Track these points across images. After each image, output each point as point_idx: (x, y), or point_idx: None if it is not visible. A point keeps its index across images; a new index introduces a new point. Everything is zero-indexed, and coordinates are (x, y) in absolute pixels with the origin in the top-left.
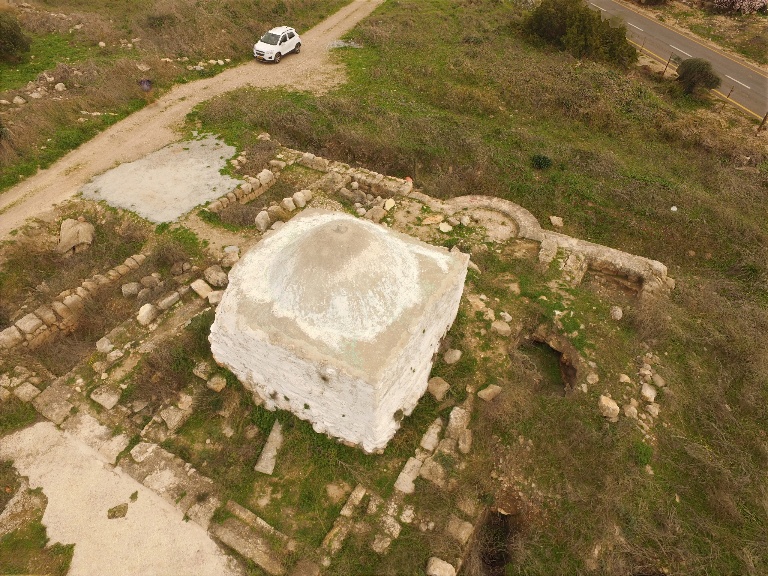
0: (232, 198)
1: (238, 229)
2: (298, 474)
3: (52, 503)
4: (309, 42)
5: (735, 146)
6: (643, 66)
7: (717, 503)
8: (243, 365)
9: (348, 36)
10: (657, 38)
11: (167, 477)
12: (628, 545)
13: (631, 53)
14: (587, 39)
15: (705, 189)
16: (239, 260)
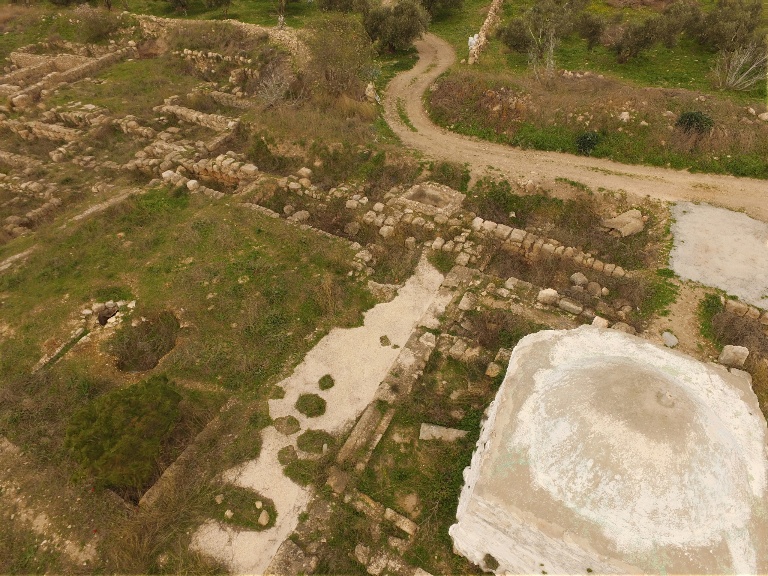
0: (766, 319)
1: (708, 336)
2: (423, 463)
3: (389, 304)
4: None
5: None
6: None
7: None
8: None
9: None
10: None
11: (409, 361)
12: None
13: None
14: None
15: None
16: None
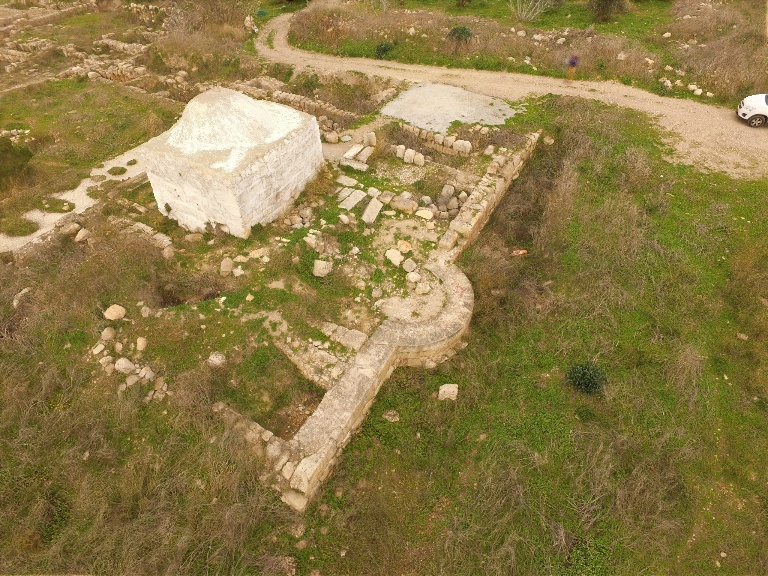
0: (422, 134)
1: None
2: None
3: None
4: None
5: None
6: None
7: None
8: None
9: None
10: None
11: None
12: None
13: None
14: None
15: None
16: None
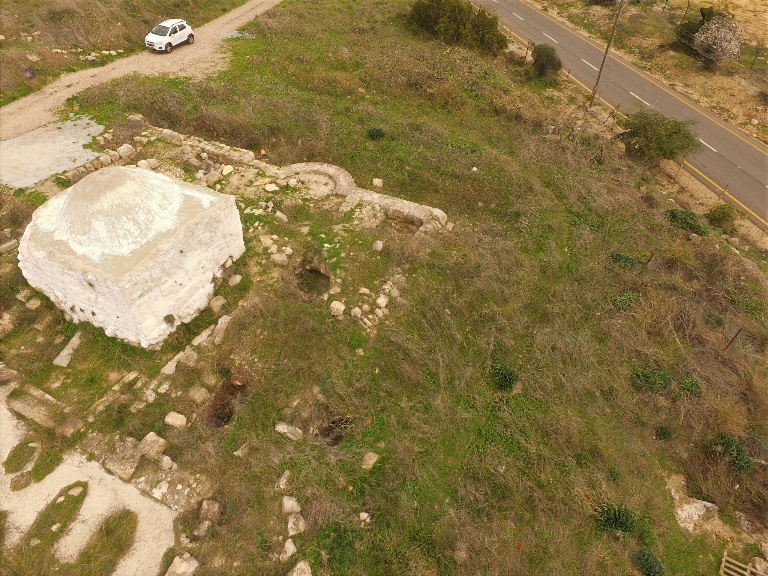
0: (90, 168)
1: None
2: (88, 366)
3: None
4: (206, 33)
5: (547, 118)
6: (509, 52)
7: (397, 369)
8: (48, 286)
9: (244, 28)
10: (533, 27)
11: None
12: (322, 399)
13: (500, 40)
14: (459, 28)
15: (510, 153)
16: (43, 204)
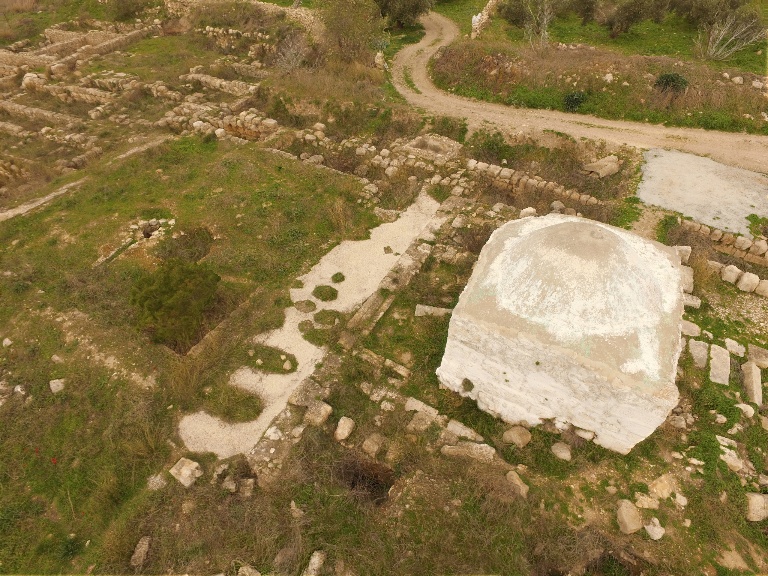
0: (715, 235)
1: None
2: (417, 332)
3: (392, 224)
4: None
5: None
6: None
7: None
8: None
9: None
10: None
11: (408, 262)
12: None
13: None
14: None
15: None
16: None
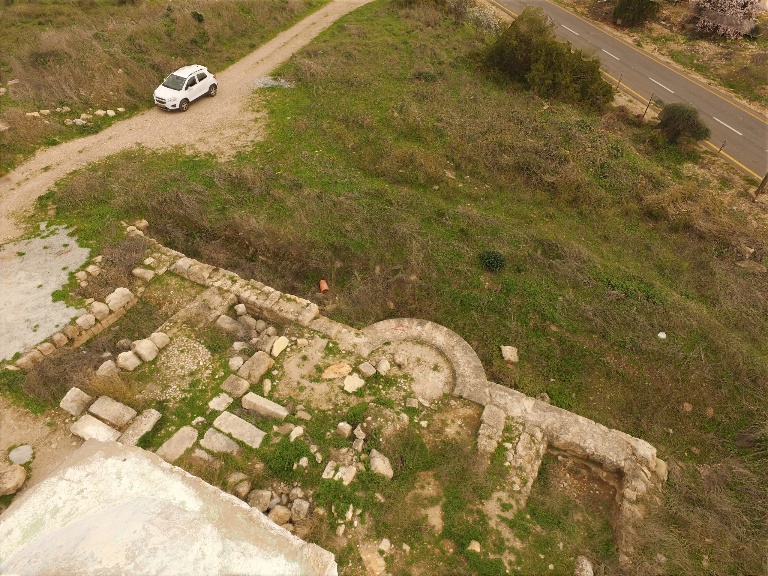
0: (60, 341)
1: (43, 410)
2: None
3: None
4: (231, 80)
5: (734, 231)
6: (620, 107)
7: None
8: None
9: (279, 72)
10: (635, 69)
11: None
12: None
13: (606, 91)
14: (555, 76)
15: (700, 298)
16: None
